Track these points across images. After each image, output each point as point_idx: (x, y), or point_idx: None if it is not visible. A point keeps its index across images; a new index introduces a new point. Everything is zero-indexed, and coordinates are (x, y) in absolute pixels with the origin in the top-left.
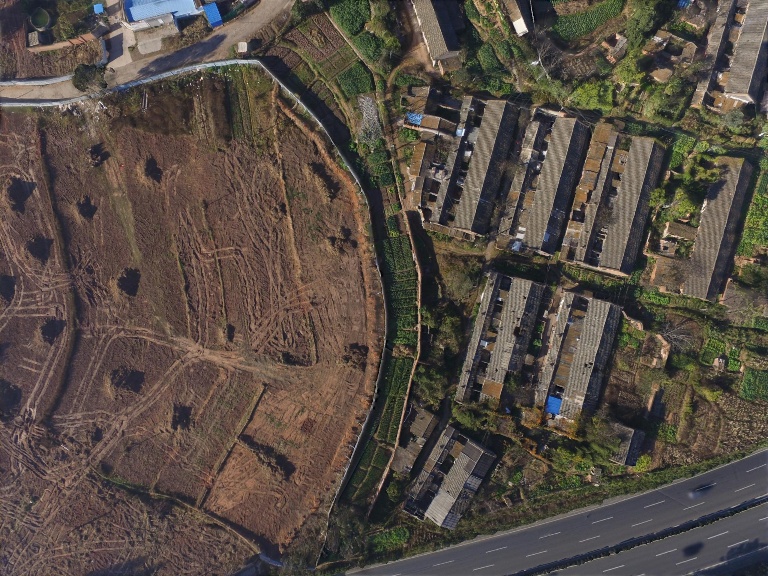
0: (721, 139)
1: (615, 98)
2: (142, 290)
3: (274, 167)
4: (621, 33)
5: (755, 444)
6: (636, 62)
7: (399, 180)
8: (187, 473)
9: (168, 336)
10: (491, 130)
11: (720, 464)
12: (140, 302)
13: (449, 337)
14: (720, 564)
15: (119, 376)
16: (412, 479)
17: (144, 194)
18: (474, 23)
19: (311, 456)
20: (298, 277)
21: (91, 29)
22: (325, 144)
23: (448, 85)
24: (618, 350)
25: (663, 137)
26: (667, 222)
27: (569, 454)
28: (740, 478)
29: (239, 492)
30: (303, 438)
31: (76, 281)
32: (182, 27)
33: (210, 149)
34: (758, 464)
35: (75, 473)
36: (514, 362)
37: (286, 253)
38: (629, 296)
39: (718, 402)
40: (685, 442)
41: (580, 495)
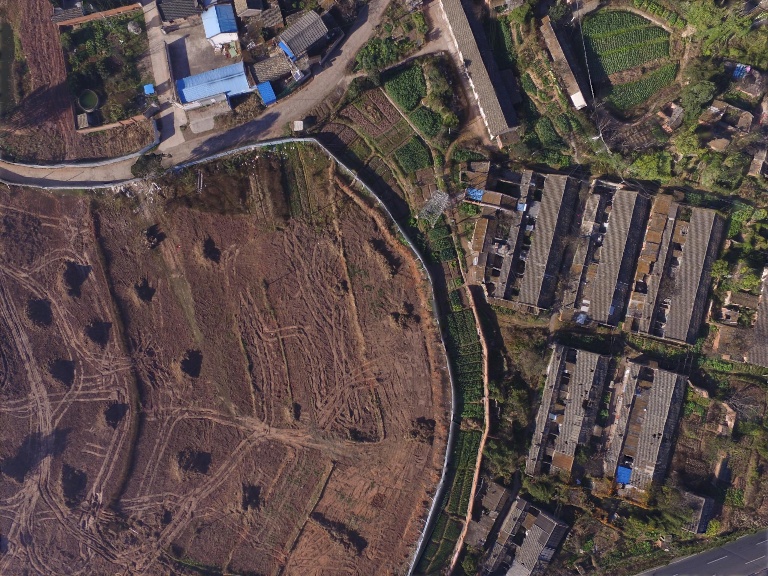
0: None
1: (673, 168)
2: (205, 371)
3: (334, 245)
4: (677, 102)
5: None
6: (698, 137)
7: (461, 255)
8: (259, 552)
9: (233, 416)
10: (553, 205)
11: None
12: (203, 383)
13: (516, 410)
14: None
15: (186, 458)
16: (485, 550)
17: (203, 275)
18: (531, 96)
19: (382, 530)
20: (362, 354)
21: (142, 110)
22: (385, 221)
23: (506, 158)
24: (684, 418)
25: (724, 208)
26: (729, 291)
27: (642, 524)
28: None
29: (312, 569)
30: (374, 513)
31: (137, 364)
32: (234, 105)
33: (268, 228)
34: None
35: (146, 556)
36: (583, 434)
37: (349, 330)
38: (692, 364)
39: None
40: (752, 505)
41: (649, 558)
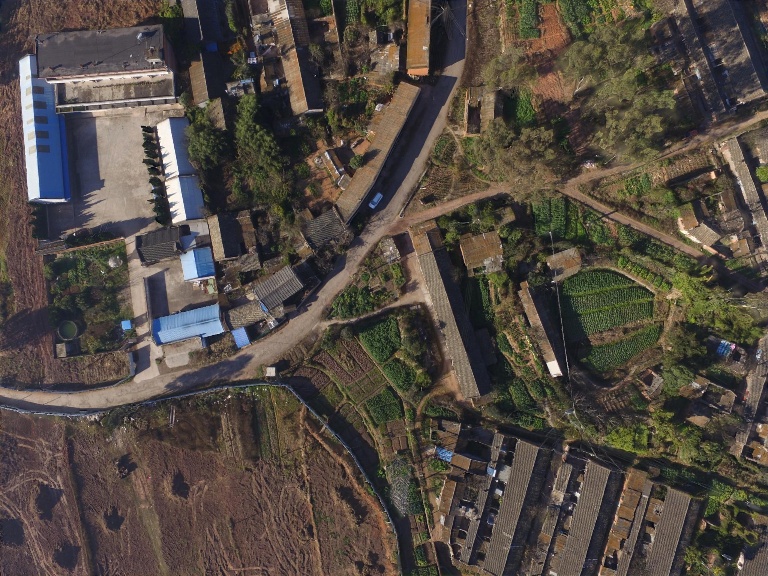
0: (759, 490)
1: (650, 439)
2: None
3: (302, 491)
4: (657, 372)
5: None
6: (674, 428)
7: (428, 511)
8: None
9: None
10: (523, 474)
11: None
12: None
13: None
14: None
15: None
16: None
17: (171, 508)
18: (506, 355)
19: None
20: None
21: (119, 344)
22: (353, 471)
23: (479, 415)
24: None
25: (700, 493)
26: (702, 575)
27: None
28: None
29: None
30: None
31: None
32: (210, 342)
33: (237, 468)
34: None
35: None
36: None
37: (313, 575)
38: None
39: None
40: None
41: None
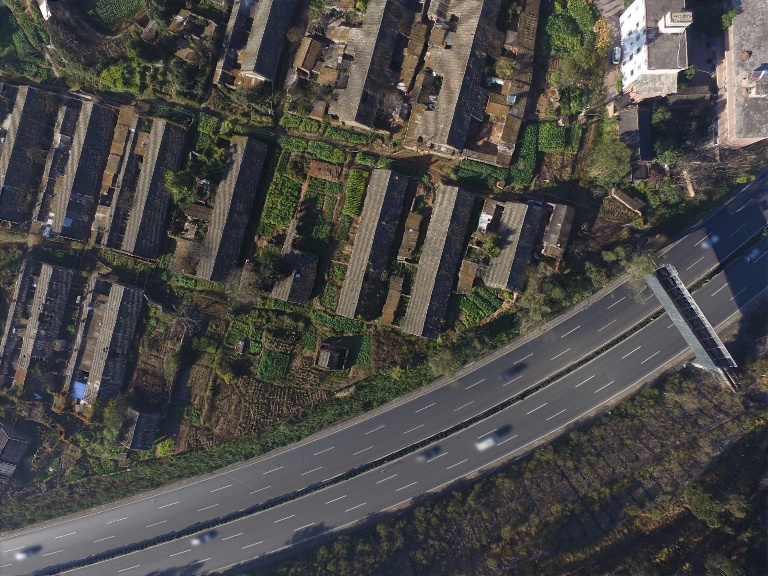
0: (243, 118)
1: (145, 80)
2: None
3: None
4: None
5: (271, 426)
6: (131, 42)
7: None
8: None
9: None
10: (17, 116)
11: (277, 447)
12: None
13: None
14: (285, 548)
15: None
16: None
17: None
18: (11, 8)
19: None
20: None
21: None
22: None
23: None
24: (145, 334)
25: (176, 118)
26: None
27: (82, 439)
28: (307, 461)
29: None
30: None
31: None
32: None
33: None
34: (326, 447)
35: None
36: (40, 348)
37: None
38: (159, 280)
39: (237, 385)
40: (208, 425)
41: (125, 480)
